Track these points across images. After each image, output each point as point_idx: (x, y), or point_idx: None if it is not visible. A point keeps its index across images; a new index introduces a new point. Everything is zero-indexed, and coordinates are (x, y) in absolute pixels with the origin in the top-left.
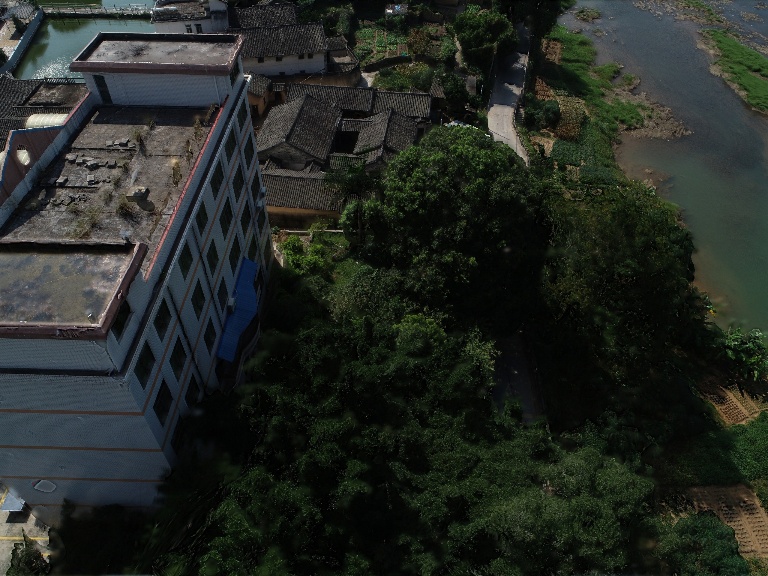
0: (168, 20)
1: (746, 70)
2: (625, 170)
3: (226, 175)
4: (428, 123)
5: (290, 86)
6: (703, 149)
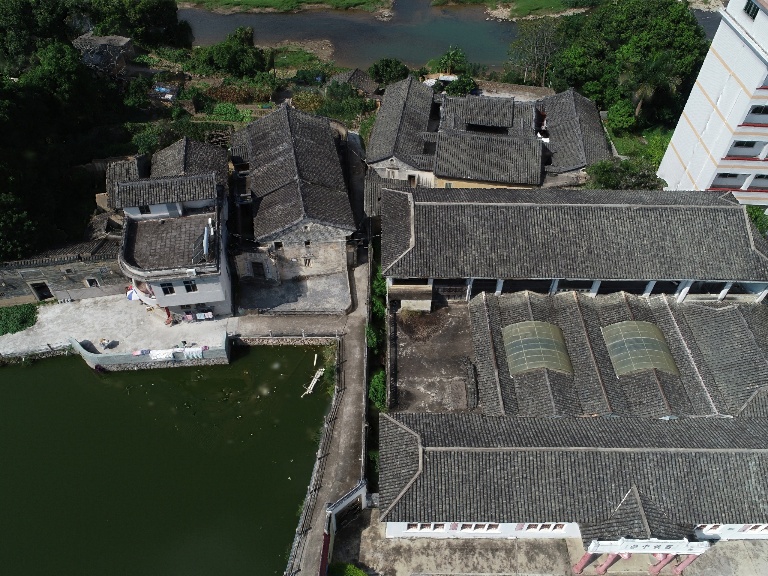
0: (219, 252)
1: (233, 0)
2: None
3: None
4: None
5: (396, 155)
6: (351, 40)
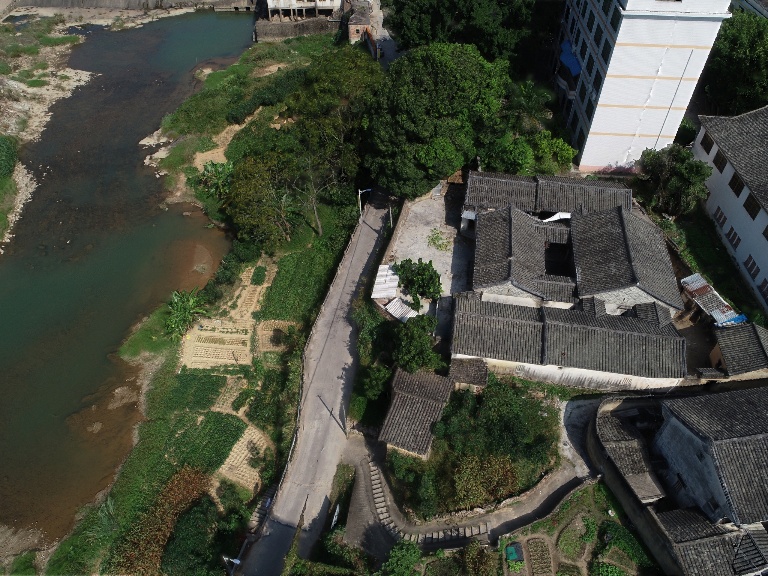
0: None
1: None
2: (134, 426)
3: (599, 6)
4: (457, 293)
5: None
6: None
